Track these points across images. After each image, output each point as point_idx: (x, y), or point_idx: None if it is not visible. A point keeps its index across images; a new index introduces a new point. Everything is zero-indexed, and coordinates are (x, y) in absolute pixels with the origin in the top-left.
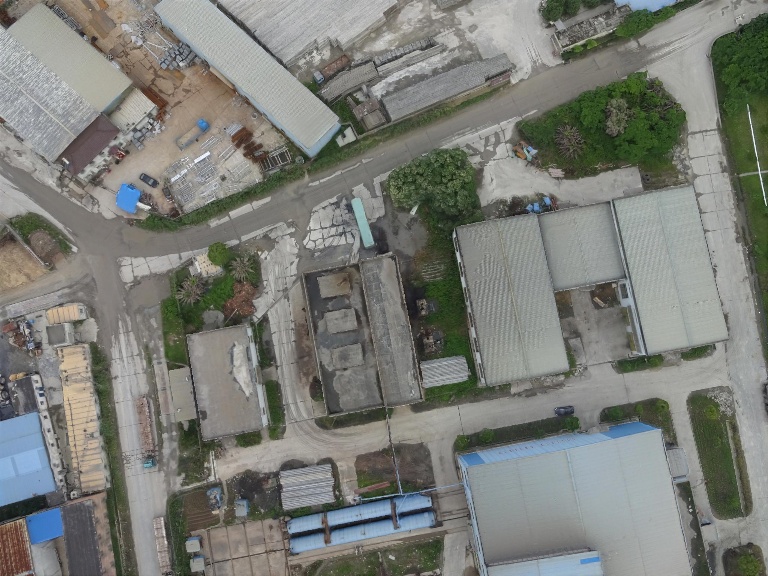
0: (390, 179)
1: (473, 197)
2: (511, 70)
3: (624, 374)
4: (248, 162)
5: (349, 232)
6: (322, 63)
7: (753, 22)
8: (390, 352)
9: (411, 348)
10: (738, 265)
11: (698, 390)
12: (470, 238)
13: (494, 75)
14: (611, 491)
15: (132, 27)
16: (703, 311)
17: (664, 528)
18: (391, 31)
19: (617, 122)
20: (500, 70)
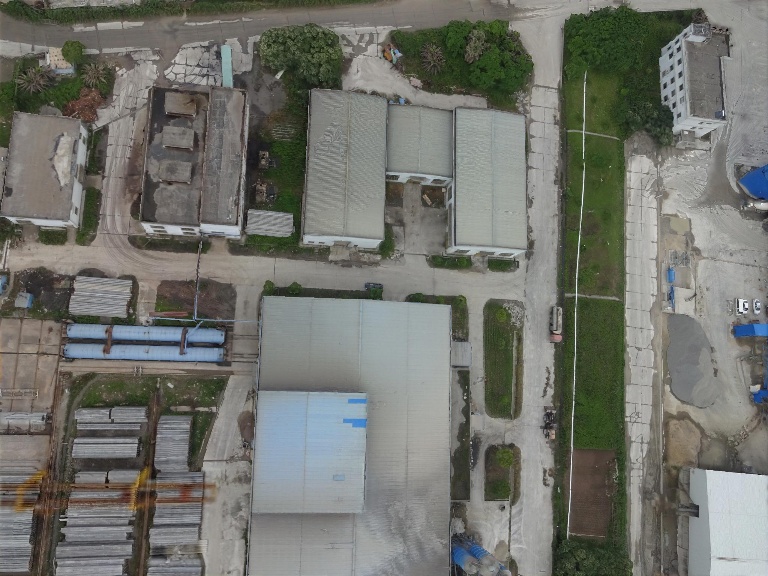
0: (263, 36)
1: (335, 74)
2: None
3: (435, 269)
4: None
5: (212, 76)
6: None
7: (601, 11)
8: (218, 175)
9: (239, 176)
10: (552, 203)
11: (496, 299)
12: (322, 104)
13: None
14: (393, 348)
15: None
16: (511, 220)
17: (434, 393)
18: None
19: (474, 48)
20: None
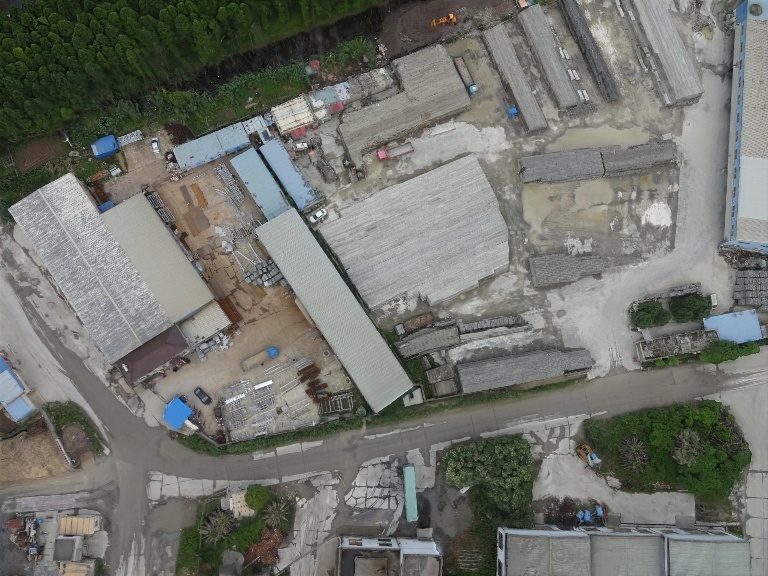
0: (449, 458)
1: (528, 496)
2: (591, 368)
3: None
4: (309, 400)
5: (394, 497)
6: (406, 313)
7: None
8: None
9: None
10: None
11: None
12: (518, 544)
13: (573, 369)
14: None
15: (226, 232)
16: None
17: None
18: (481, 297)
19: (686, 455)
20: (580, 367)
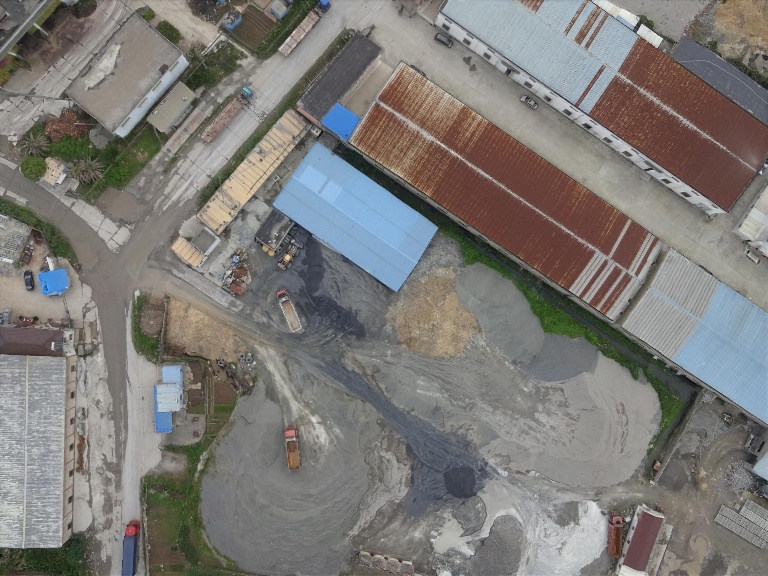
0: None
1: None
2: None
3: None
4: None
5: None
6: None
7: None
8: None
9: None
10: None
11: None
12: None
13: None
14: None
15: None
16: None
17: None
18: None
19: None
20: None
